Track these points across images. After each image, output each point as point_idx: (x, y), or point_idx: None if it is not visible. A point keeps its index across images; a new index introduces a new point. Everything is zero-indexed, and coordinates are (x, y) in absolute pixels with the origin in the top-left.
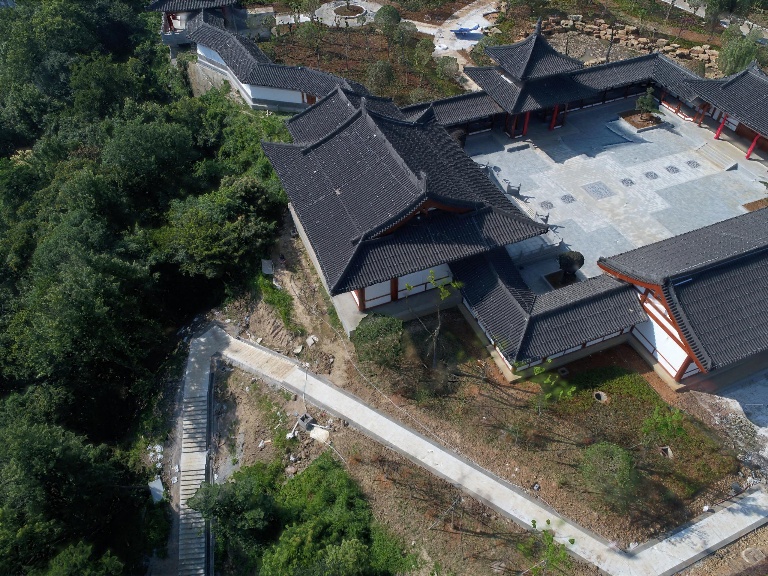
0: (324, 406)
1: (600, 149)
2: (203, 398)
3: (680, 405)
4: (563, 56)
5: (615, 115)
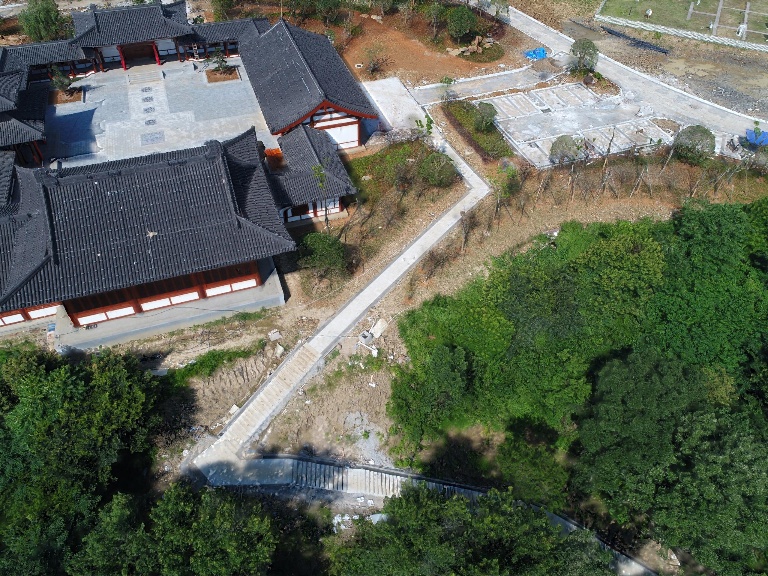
0: (355, 322)
1: (95, 126)
2: (295, 463)
3: (376, 151)
4: (0, 74)
5: (49, 107)
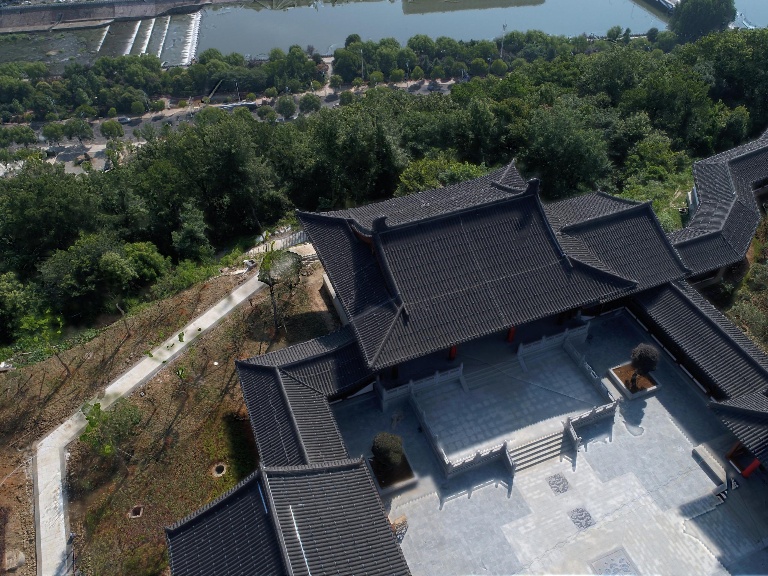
0: None
1: None
2: None
3: None
4: None
5: None
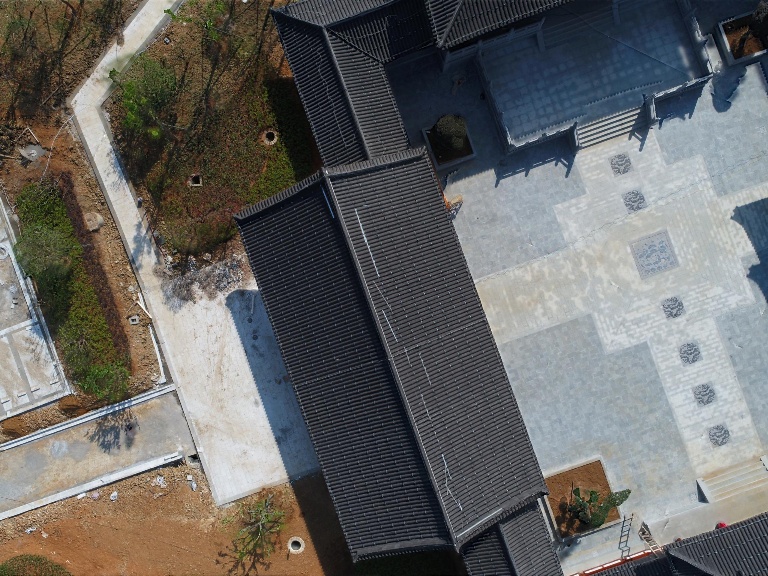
0: None
1: None
2: None
3: None
4: None
5: None
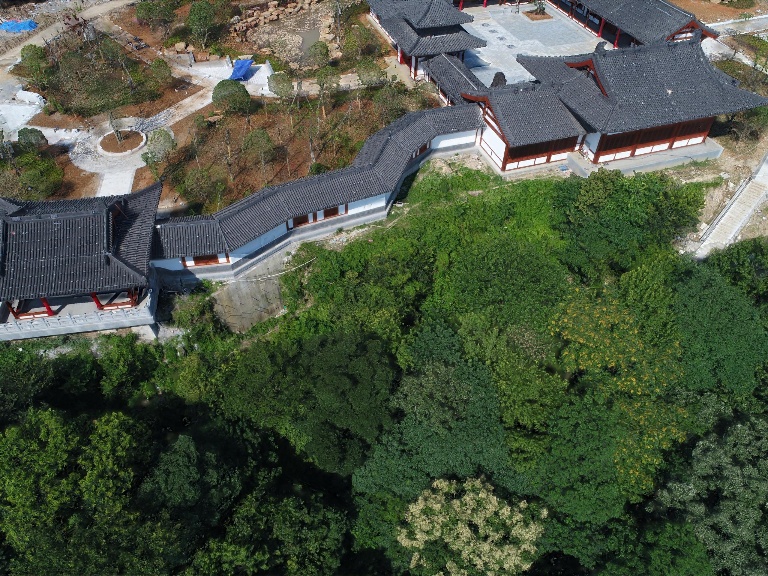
0: None
1: None
2: None
3: None
4: None
5: None
